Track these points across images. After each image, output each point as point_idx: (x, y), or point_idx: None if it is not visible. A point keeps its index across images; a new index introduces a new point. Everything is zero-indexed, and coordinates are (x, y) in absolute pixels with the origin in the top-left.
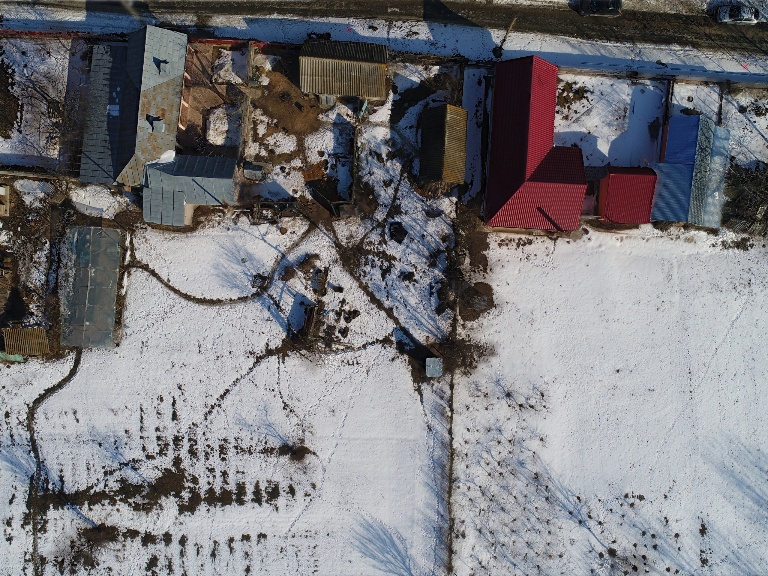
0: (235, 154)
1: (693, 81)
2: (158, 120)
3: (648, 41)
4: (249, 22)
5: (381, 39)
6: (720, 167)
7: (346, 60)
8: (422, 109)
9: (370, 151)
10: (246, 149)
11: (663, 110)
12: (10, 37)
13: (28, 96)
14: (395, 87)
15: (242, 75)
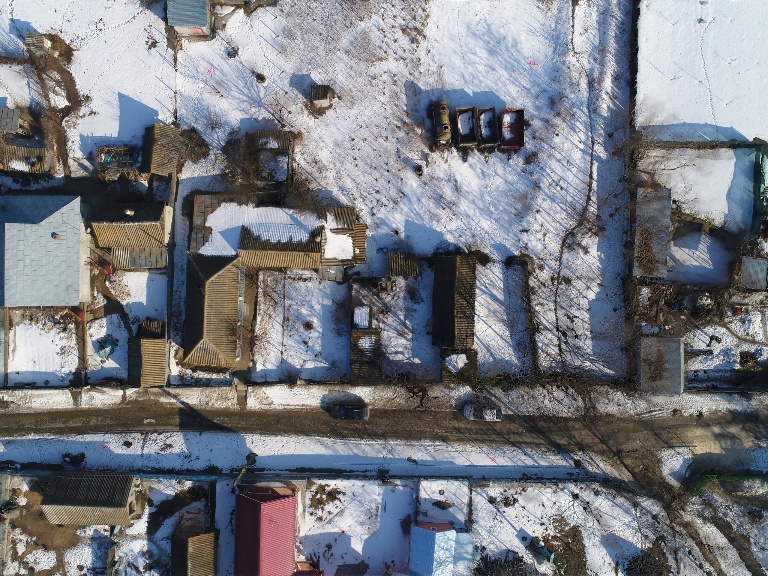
0: None
1: (442, 477)
2: None
3: (399, 437)
4: (6, 444)
5: (135, 456)
6: (464, 571)
7: (85, 506)
8: (178, 520)
9: (128, 563)
10: (4, 571)
11: (414, 506)
12: None
13: None
14: (151, 500)
15: None
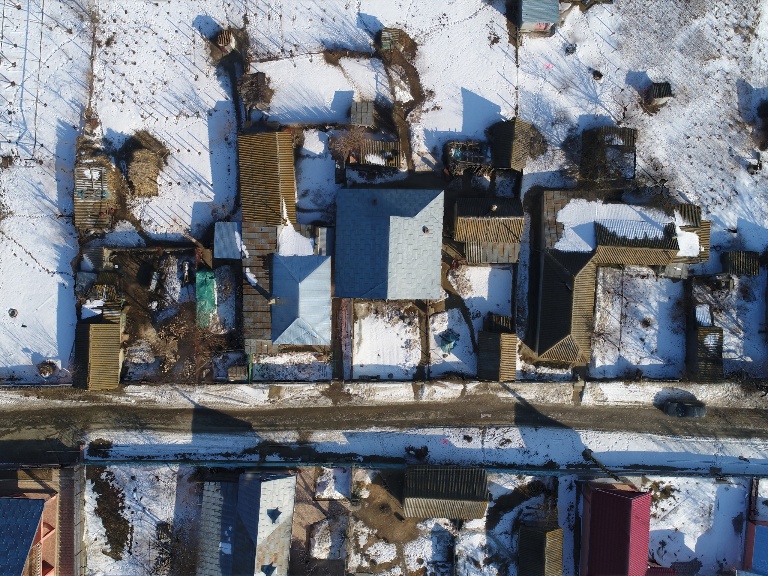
0: (338, 567)
1: None
2: (272, 570)
3: (730, 435)
4: (349, 437)
5: (476, 450)
6: None
7: (450, 499)
8: (516, 515)
9: (467, 557)
10: (349, 563)
11: (746, 505)
12: (120, 463)
13: (138, 519)
14: (490, 495)
15: (344, 491)
